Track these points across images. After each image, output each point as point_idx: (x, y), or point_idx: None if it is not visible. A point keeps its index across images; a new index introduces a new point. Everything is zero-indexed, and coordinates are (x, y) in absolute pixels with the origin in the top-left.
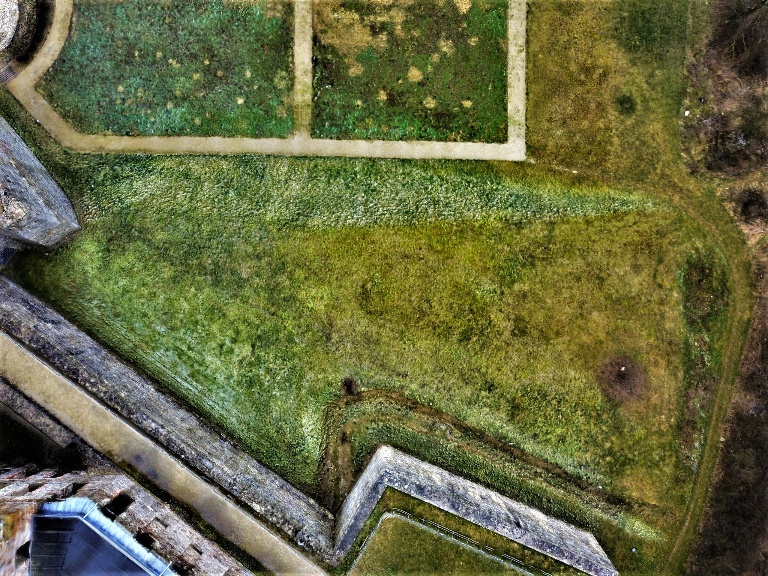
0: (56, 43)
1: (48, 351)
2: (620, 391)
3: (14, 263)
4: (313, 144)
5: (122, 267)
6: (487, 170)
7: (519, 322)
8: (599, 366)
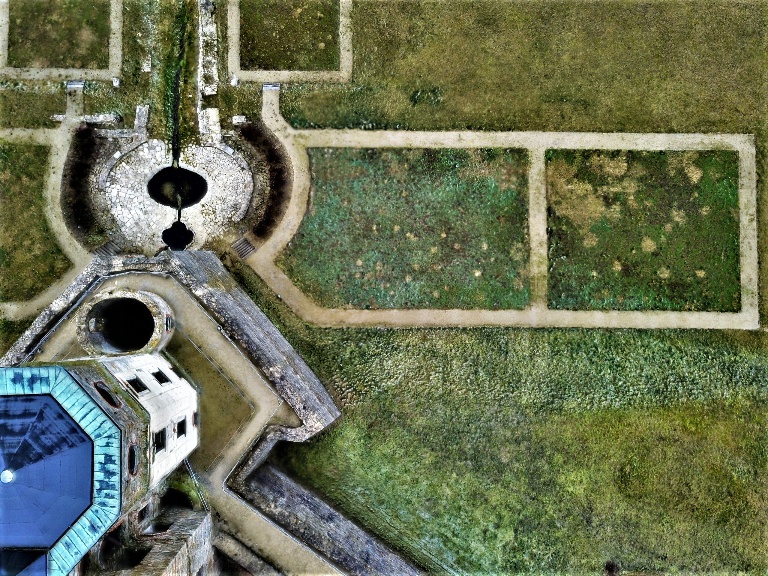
0: (295, 218)
1: (350, 564)
2: None
3: (276, 451)
4: (550, 315)
5: (384, 454)
6: (722, 339)
7: None
8: None
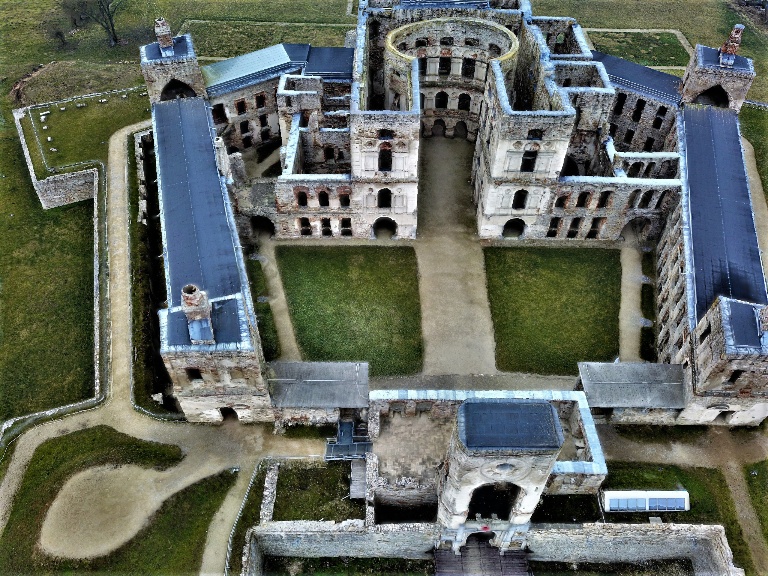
0: None
1: None
2: None
3: None
4: None
5: None
6: None
7: None
8: None
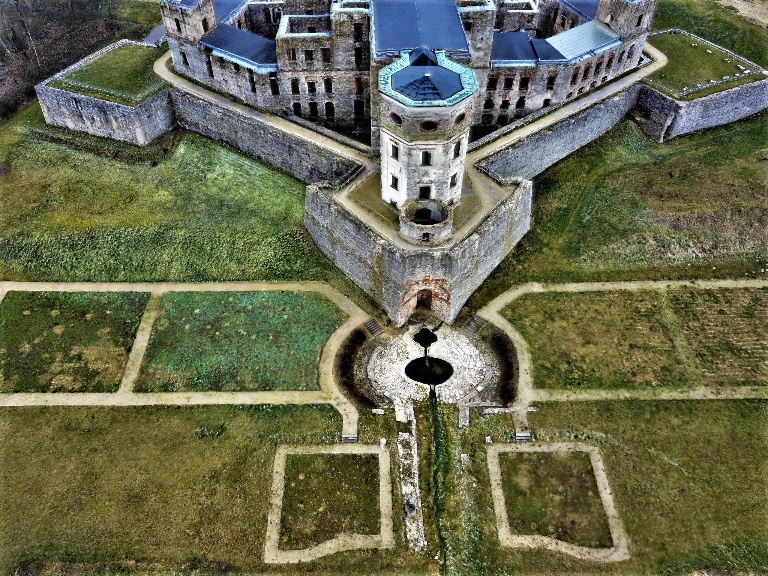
0: (333, 343)
1: (297, 142)
2: (0, 167)
3: None
4: (151, 289)
5: (278, 207)
6: (31, 276)
7: (44, 190)
8: (6, 175)
